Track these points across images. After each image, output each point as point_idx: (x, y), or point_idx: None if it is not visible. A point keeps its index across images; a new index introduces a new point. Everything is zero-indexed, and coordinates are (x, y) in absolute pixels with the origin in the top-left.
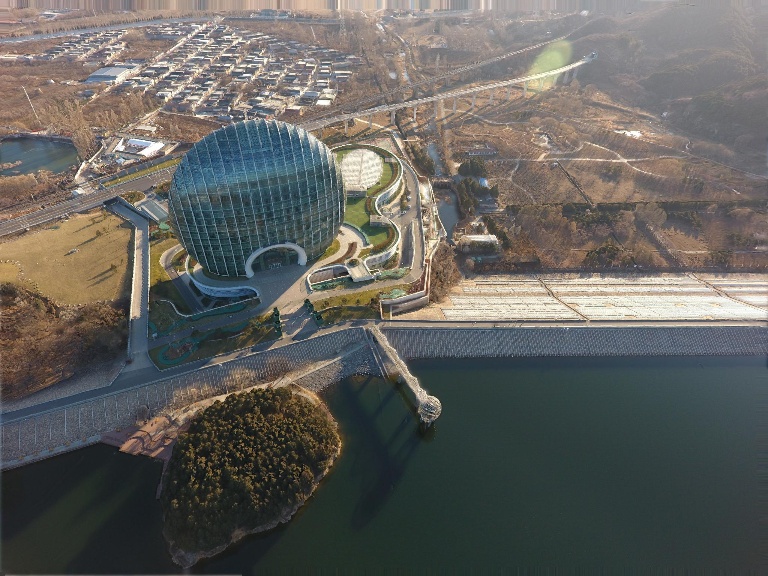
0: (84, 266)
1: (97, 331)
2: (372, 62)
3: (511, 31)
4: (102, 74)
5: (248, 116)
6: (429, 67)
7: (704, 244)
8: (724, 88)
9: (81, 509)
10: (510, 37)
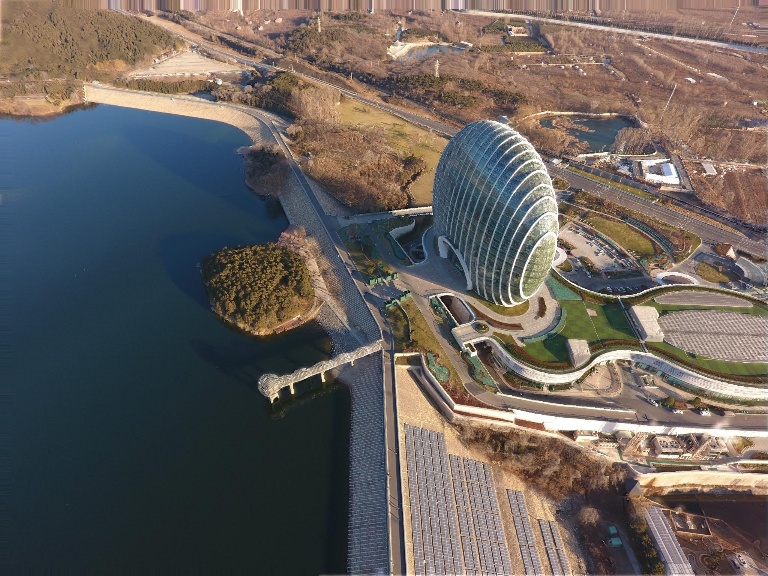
0: None
1: (370, 197)
2: None
3: None
4: None
5: None
6: None
7: None
8: None
9: (250, 229)
10: None
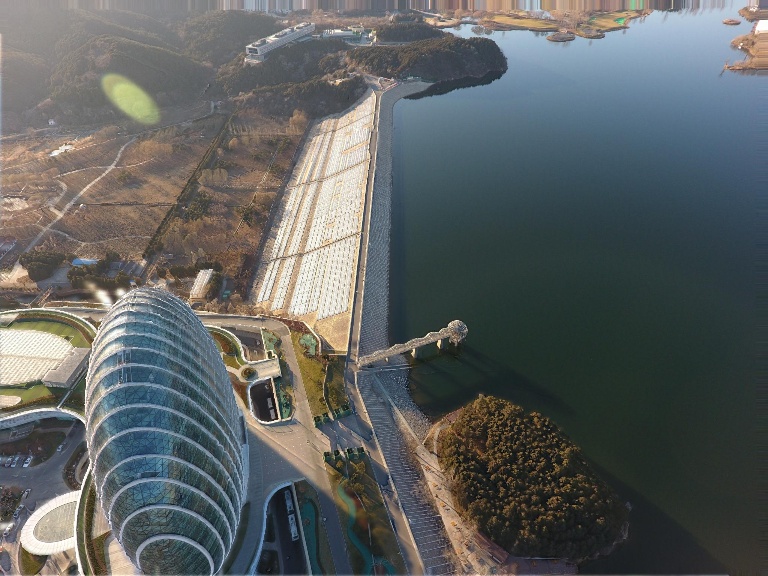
0: None
1: None
2: None
3: None
4: None
5: None
6: None
7: (257, 171)
8: (56, 80)
9: None
10: None
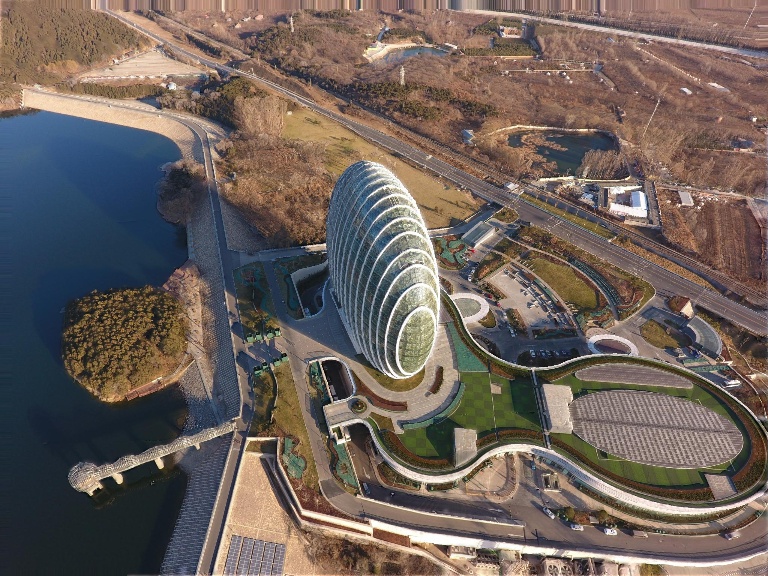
0: None
1: (281, 229)
2: None
3: None
4: None
5: None
6: None
7: None
8: None
9: (143, 264)
10: None
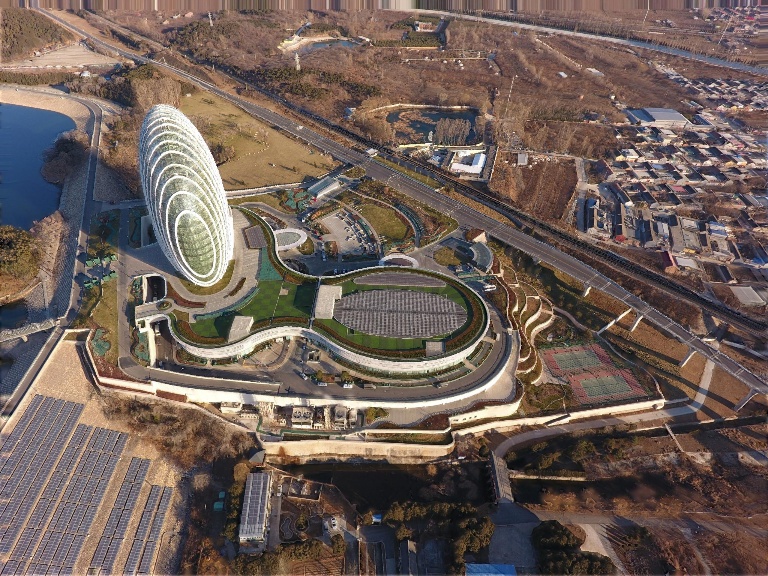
0: (250, 172)
1: None
2: None
3: None
4: (649, 111)
5: (609, 219)
6: None
7: None
8: None
9: (17, 214)
10: None
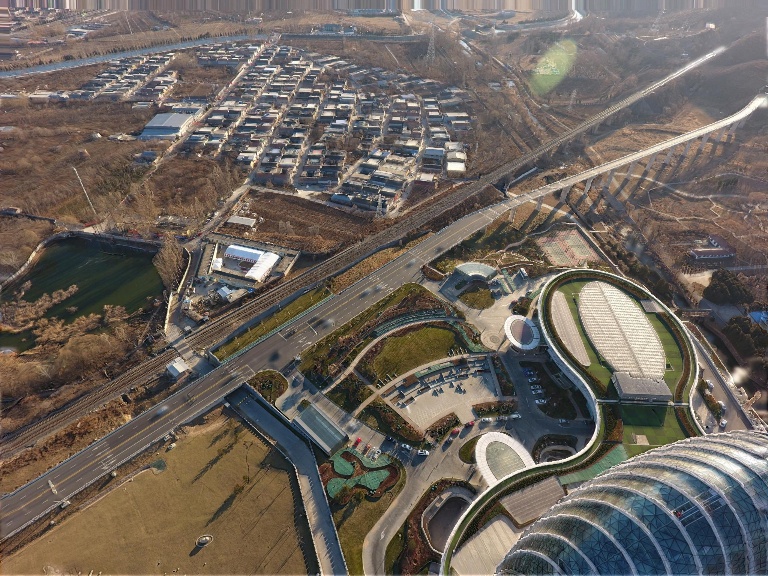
0: None
1: None
2: (483, 97)
3: (629, 50)
4: (161, 125)
5: (371, 195)
6: (555, 103)
7: None
8: None
9: None
10: (635, 60)
